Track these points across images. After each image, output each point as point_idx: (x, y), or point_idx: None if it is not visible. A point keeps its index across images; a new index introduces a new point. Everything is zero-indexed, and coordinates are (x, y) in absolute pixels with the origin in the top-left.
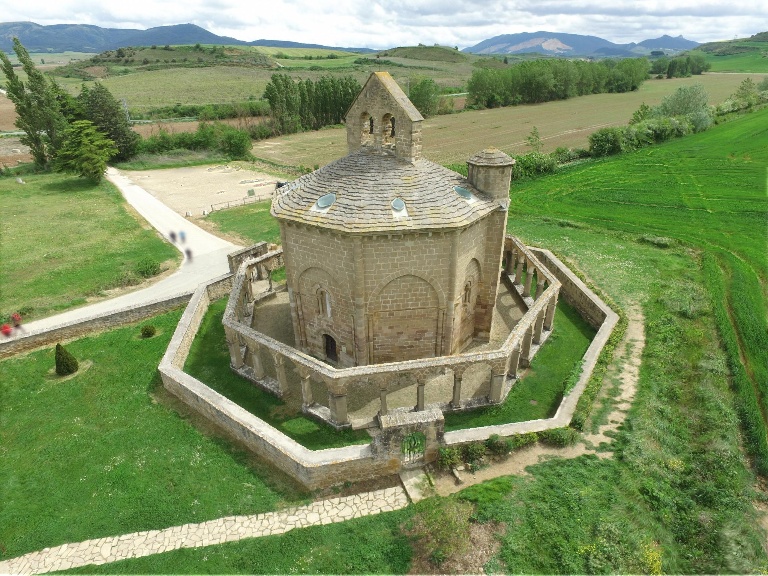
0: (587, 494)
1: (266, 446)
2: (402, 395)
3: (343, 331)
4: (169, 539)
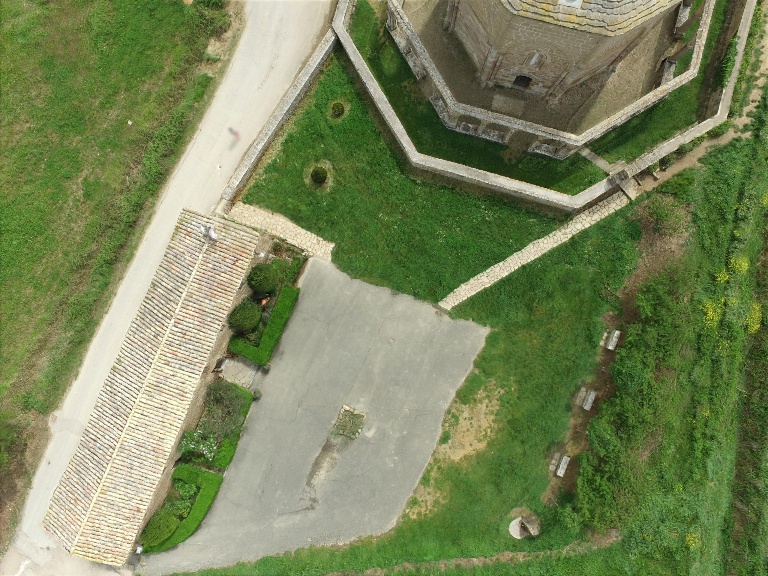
0: (738, 173)
1: (538, 198)
2: (589, 108)
3: (547, 76)
4: (512, 263)
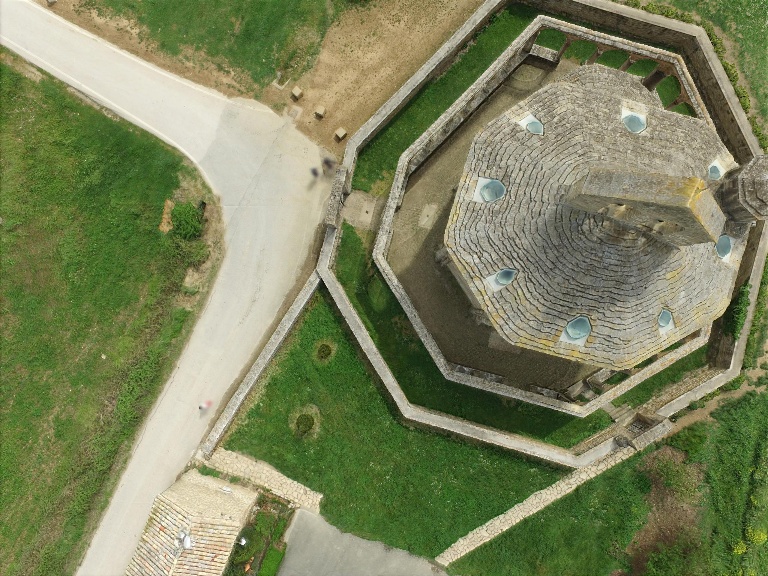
0: (754, 433)
1: None
2: None
3: None
4: (513, 516)
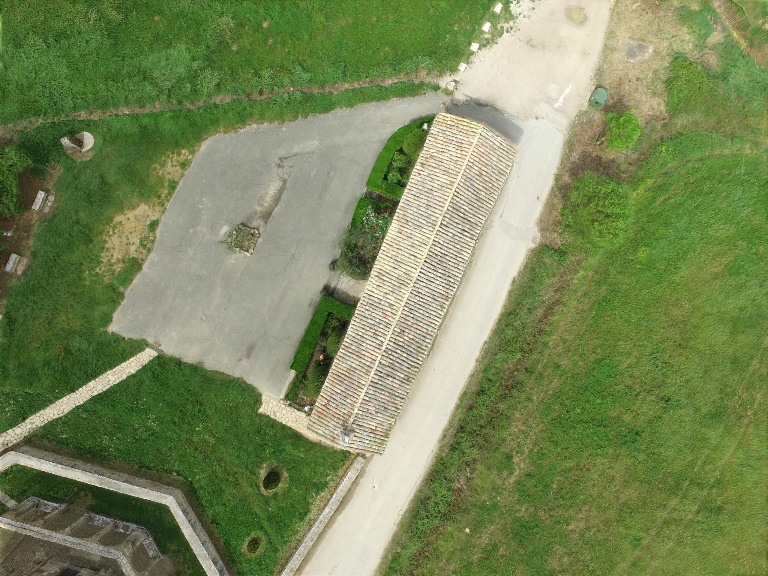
0: None
1: None
2: (6, 548)
3: None
4: (84, 394)
